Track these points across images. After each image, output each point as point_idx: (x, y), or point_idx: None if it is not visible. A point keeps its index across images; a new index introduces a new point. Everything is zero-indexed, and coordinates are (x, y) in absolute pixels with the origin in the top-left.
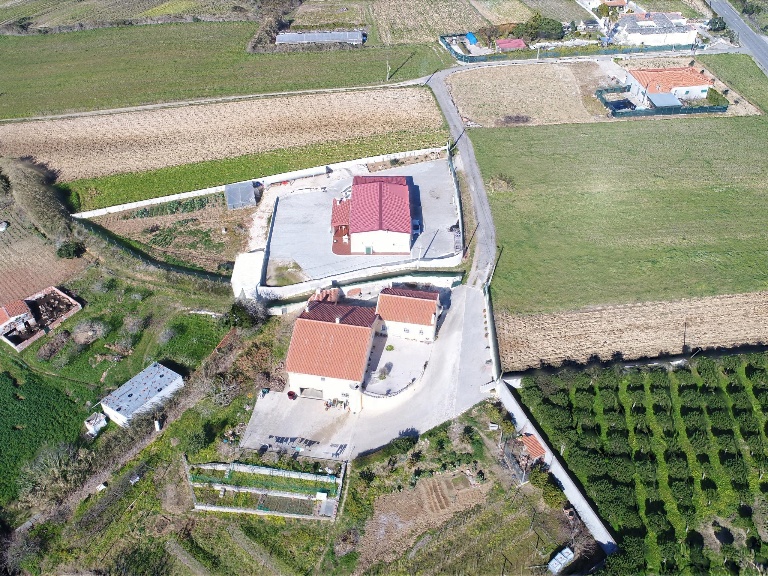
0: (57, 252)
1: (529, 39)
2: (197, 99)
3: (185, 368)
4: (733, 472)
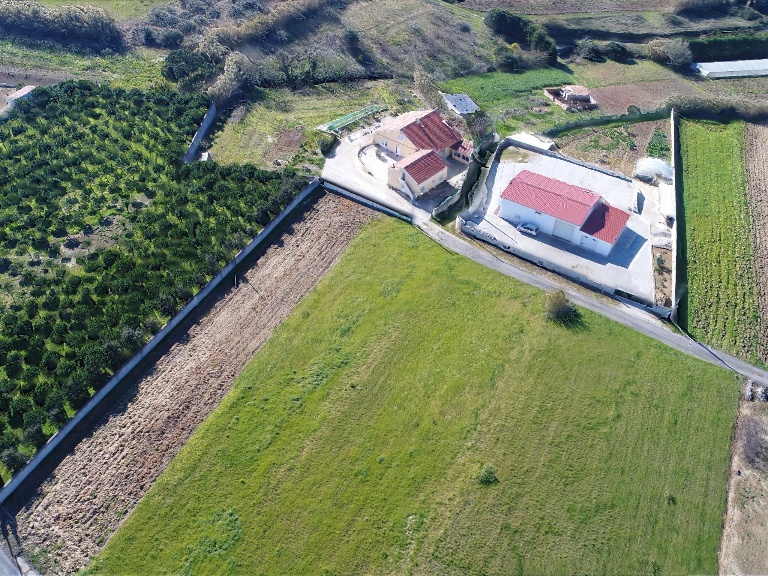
0: None
1: None
2: None
3: None
4: None
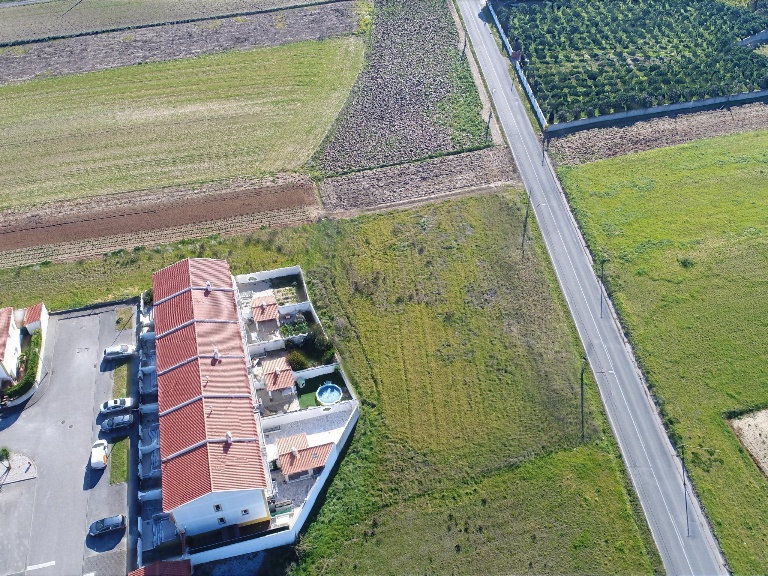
0: None
1: None
2: None
3: None
4: None
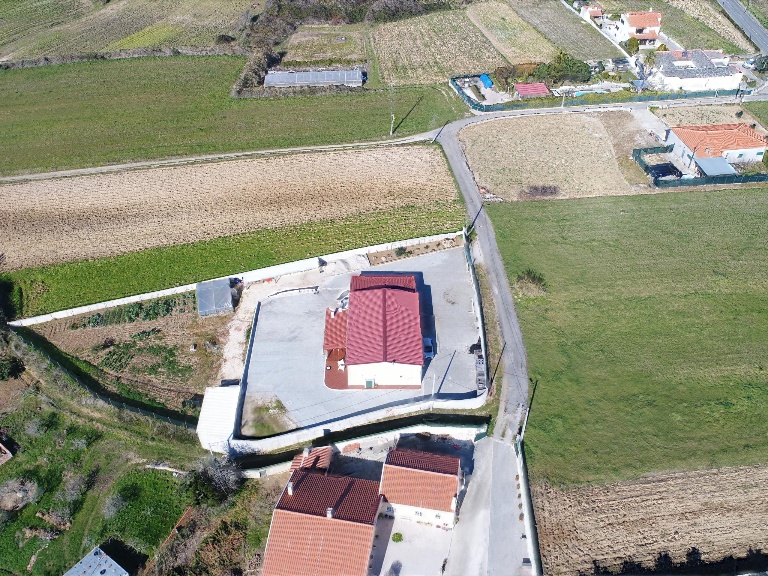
0: None
1: (551, 81)
2: (171, 158)
3: (134, 557)
4: None
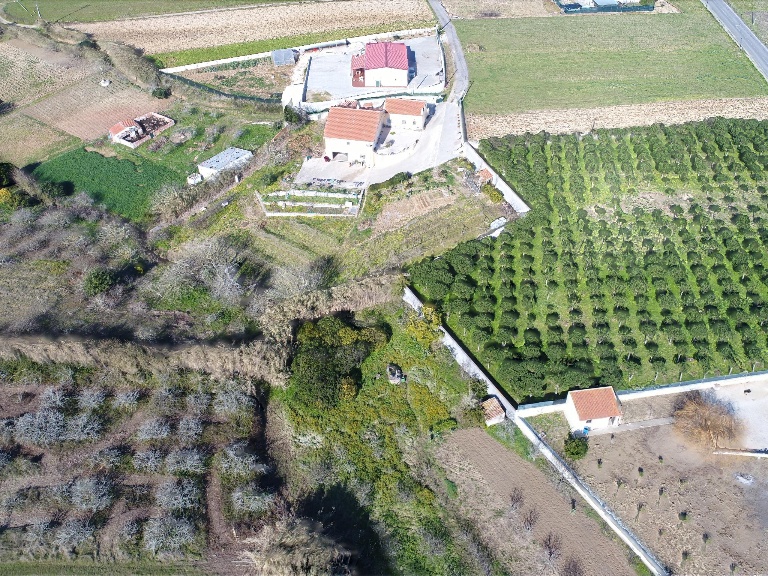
0: (152, 92)
1: None
2: (242, 6)
3: None
4: (610, 179)
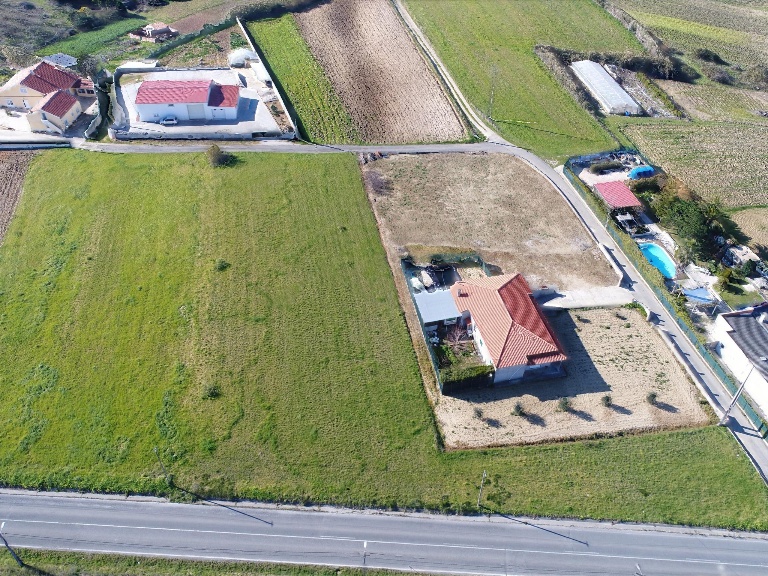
0: None
1: None
2: None
3: None
4: None
